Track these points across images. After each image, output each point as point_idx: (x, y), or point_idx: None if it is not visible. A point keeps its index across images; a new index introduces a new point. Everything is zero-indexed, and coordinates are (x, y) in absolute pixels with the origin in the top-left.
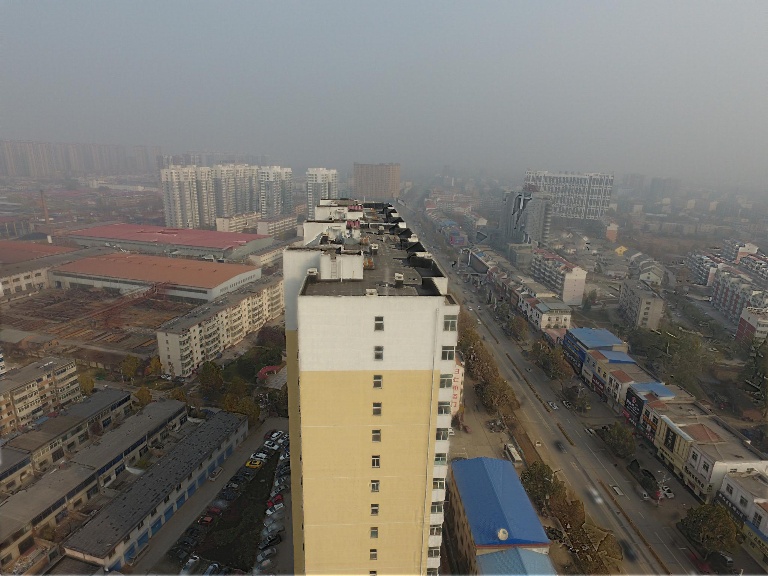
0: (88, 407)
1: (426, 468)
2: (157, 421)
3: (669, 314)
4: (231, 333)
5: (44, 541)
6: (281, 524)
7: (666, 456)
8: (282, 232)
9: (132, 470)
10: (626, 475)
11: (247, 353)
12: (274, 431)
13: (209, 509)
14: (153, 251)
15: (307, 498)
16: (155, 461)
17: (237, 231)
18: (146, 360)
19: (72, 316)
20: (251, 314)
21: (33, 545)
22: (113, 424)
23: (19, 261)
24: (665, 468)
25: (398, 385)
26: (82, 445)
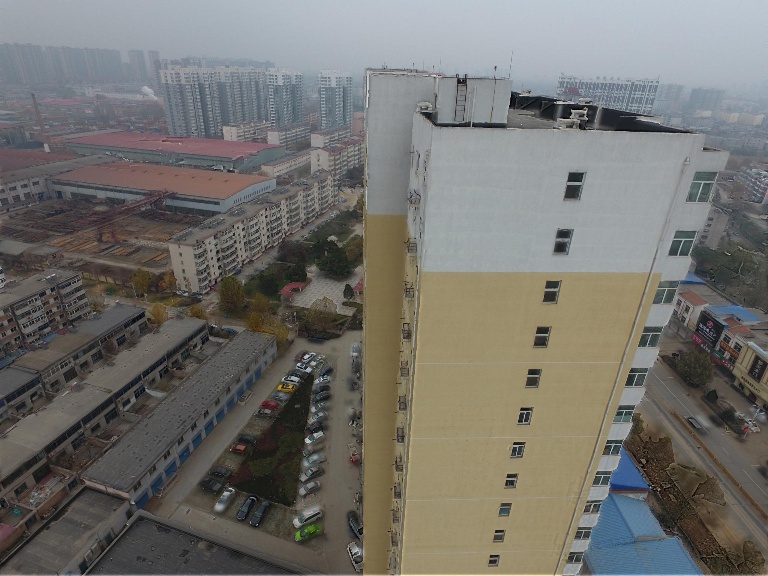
0: (99, 324)
1: (600, 426)
2: (176, 340)
3: (728, 232)
4: (249, 247)
5: (61, 469)
6: (322, 454)
7: (749, 386)
8: (295, 142)
9: (153, 393)
10: (701, 406)
11: (268, 269)
12: (305, 352)
13: (241, 436)
14: (158, 161)
15: (414, 465)
16: (177, 383)
17: None
18: (159, 275)
19: (76, 228)
20: (269, 227)
21: (50, 473)
22: (128, 343)
23: (14, 169)
24: (745, 399)
25: (585, 298)
26: (96, 364)
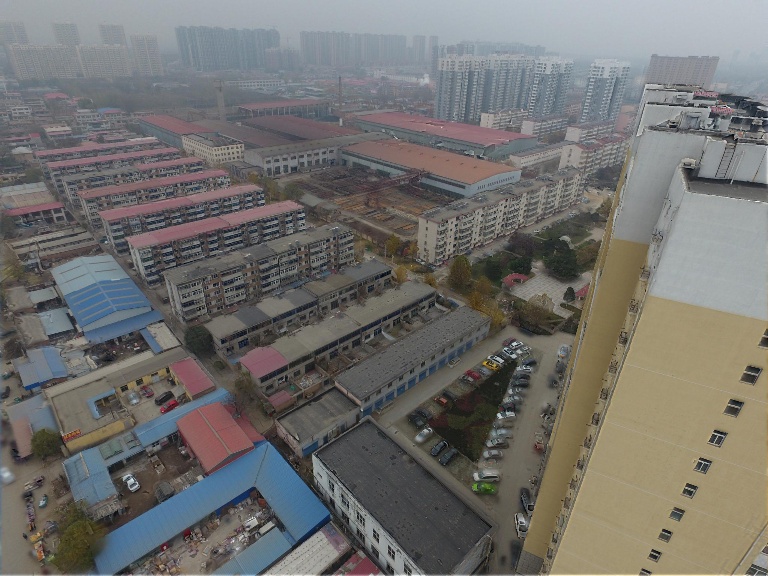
0: (359, 272)
1: None
2: (411, 299)
3: None
4: (483, 232)
5: (321, 369)
6: (510, 432)
7: None
8: (548, 134)
9: (386, 335)
10: None
11: (495, 255)
12: (514, 340)
13: (445, 392)
14: (420, 141)
15: (601, 443)
16: (405, 333)
17: (500, 128)
18: (405, 242)
19: (352, 191)
20: (506, 217)
21: (314, 369)
22: (376, 291)
23: (320, 138)
24: None
25: None
26: (351, 302)
